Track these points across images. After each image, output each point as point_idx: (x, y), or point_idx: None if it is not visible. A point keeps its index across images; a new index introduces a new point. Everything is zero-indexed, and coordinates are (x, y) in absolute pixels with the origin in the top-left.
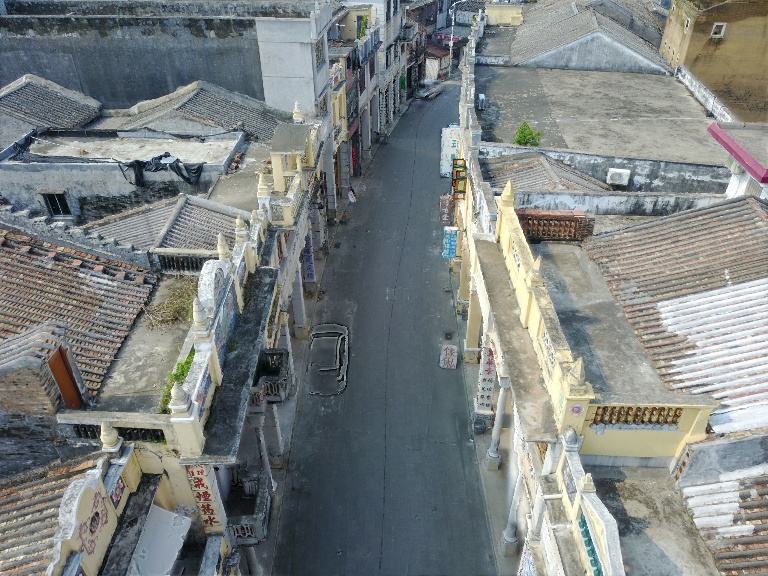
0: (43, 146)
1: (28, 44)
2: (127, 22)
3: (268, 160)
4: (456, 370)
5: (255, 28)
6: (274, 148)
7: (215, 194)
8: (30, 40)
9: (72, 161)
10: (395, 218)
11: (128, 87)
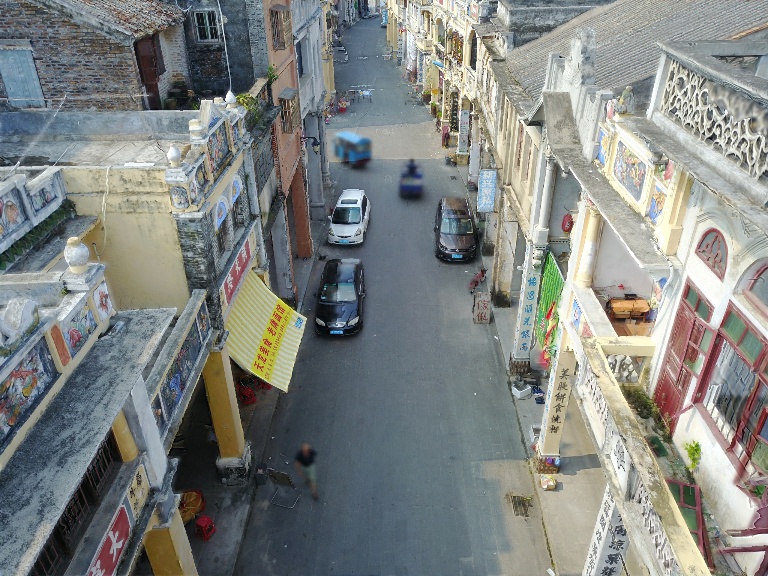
0: None
1: None
2: None
3: None
4: (390, 60)
5: None
6: None
7: None
8: None
9: None
10: (359, 41)
11: None
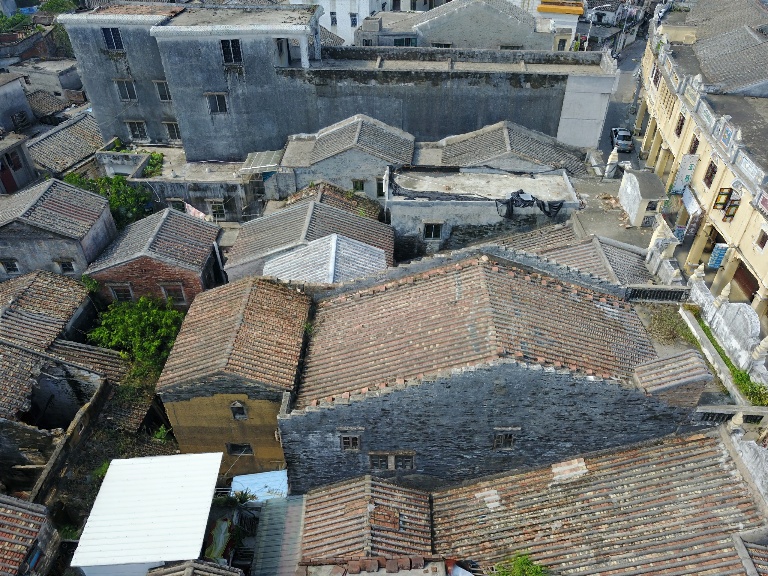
0: (406, 181)
1: (367, 91)
2: (458, 75)
3: (603, 196)
4: None
5: (566, 81)
6: (643, 195)
7: (586, 228)
8: (370, 88)
9: (447, 197)
10: None
11: (442, 125)
